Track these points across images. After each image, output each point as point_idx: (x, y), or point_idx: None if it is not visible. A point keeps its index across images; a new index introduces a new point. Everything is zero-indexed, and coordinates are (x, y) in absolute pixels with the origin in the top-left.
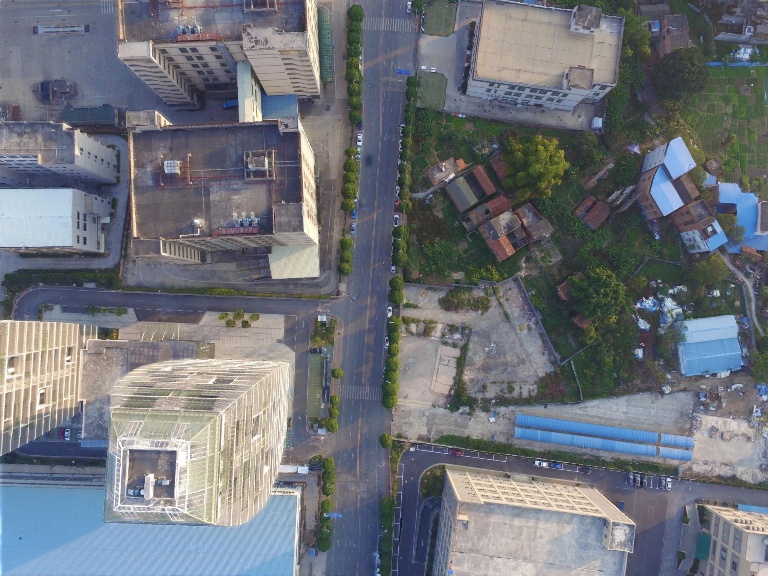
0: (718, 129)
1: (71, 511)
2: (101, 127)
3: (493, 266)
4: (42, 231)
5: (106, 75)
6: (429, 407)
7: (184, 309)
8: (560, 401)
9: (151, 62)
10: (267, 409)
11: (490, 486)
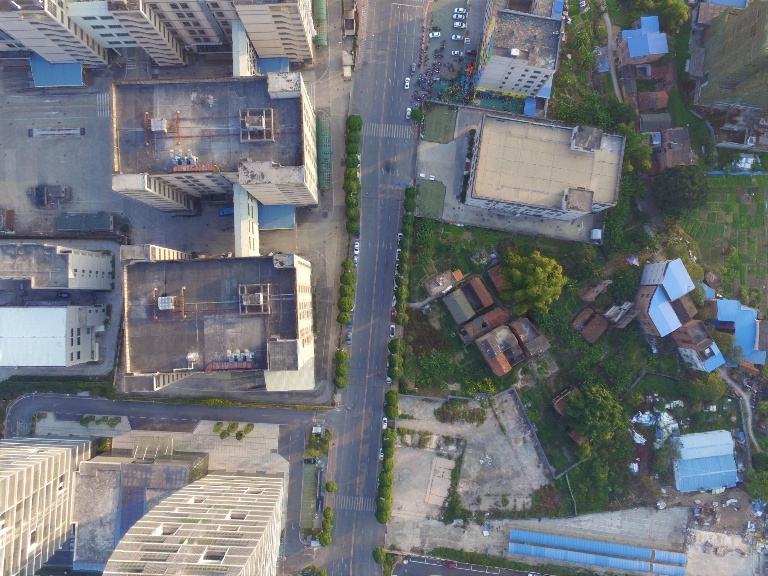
0: (718, 239)
1: None
2: (96, 232)
3: (489, 379)
4: (35, 351)
5: (102, 179)
6: (423, 519)
7: (178, 418)
8: (554, 515)
9: (146, 191)
10: (258, 575)
11: None
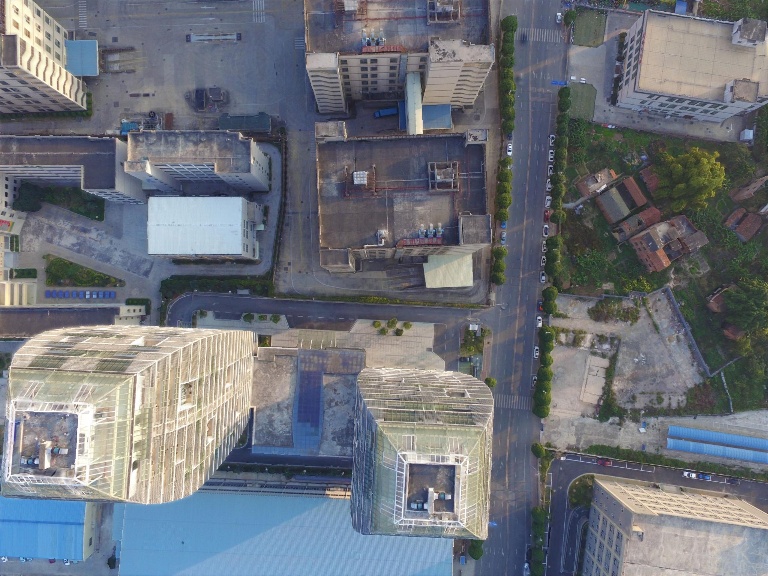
0: None
1: (232, 516)
2: (253, 135)
3: (644, 277)
4: (212, 239)
5: (258, 83)
6: (578, 417)
7: (335, 317)
8: (710, 412)
9: (334, 73)
10: None
11: (648, 497)
